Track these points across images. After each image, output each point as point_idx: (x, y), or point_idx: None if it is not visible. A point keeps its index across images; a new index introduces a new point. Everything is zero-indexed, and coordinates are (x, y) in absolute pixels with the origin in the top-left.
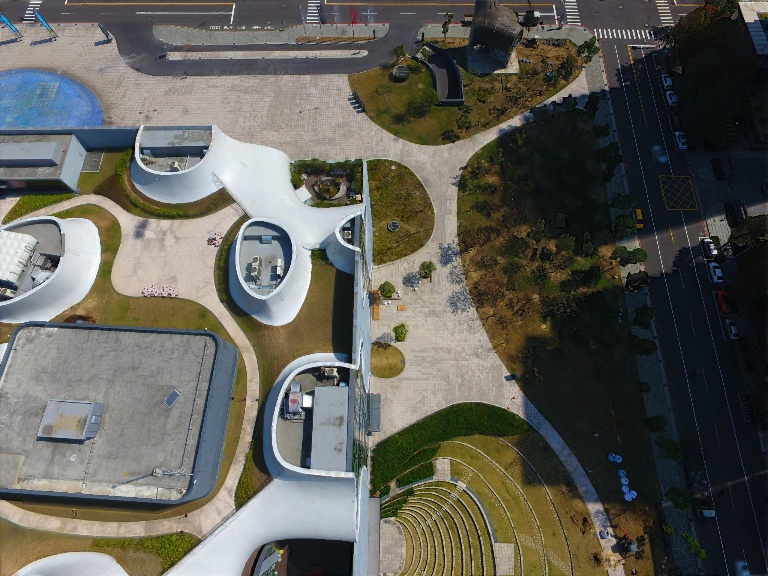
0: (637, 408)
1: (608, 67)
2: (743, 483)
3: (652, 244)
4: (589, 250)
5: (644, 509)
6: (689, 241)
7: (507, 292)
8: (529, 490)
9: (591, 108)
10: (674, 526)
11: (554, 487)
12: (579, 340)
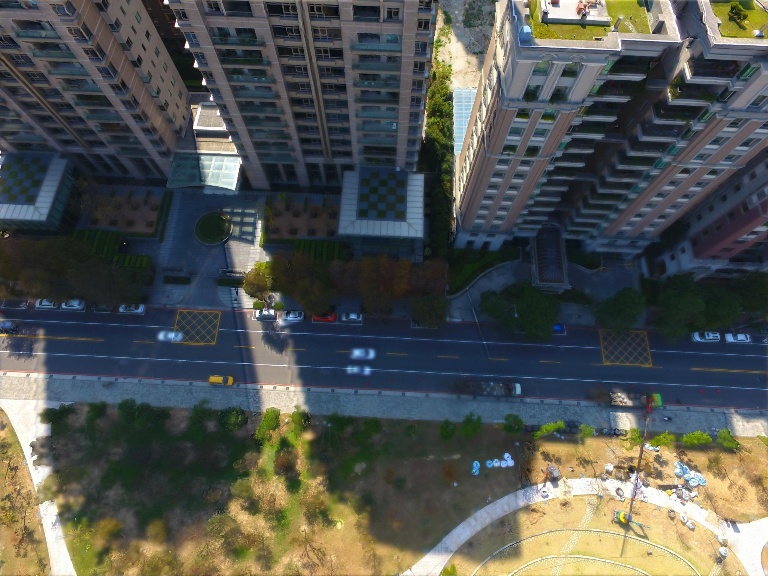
0: (426, 428)
1: (1, 366)
2: (488, 346)
3: (253, 370)
4: (255, 459)
5: (518, 447)
6: (255, 331)
7: (294, 570)
8: (509, 566)
9: (59, 416)
10: (528, 418)
11: (506, 538)
12: (365, 509)
